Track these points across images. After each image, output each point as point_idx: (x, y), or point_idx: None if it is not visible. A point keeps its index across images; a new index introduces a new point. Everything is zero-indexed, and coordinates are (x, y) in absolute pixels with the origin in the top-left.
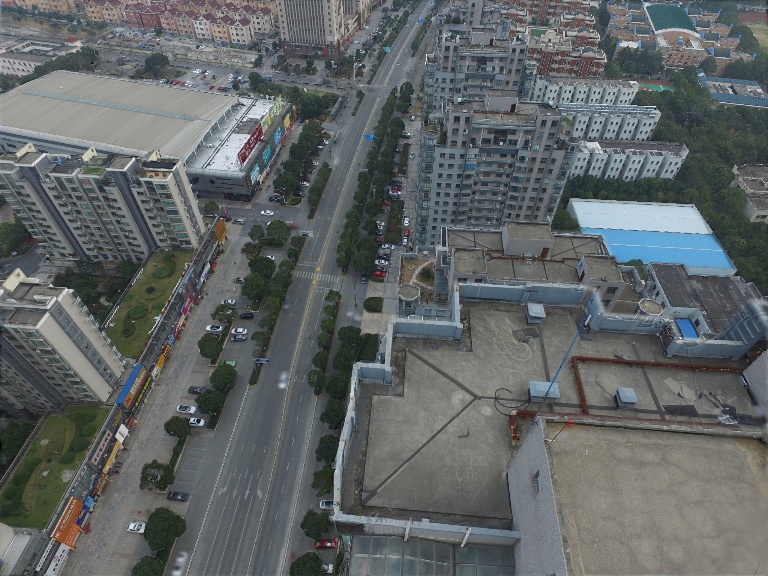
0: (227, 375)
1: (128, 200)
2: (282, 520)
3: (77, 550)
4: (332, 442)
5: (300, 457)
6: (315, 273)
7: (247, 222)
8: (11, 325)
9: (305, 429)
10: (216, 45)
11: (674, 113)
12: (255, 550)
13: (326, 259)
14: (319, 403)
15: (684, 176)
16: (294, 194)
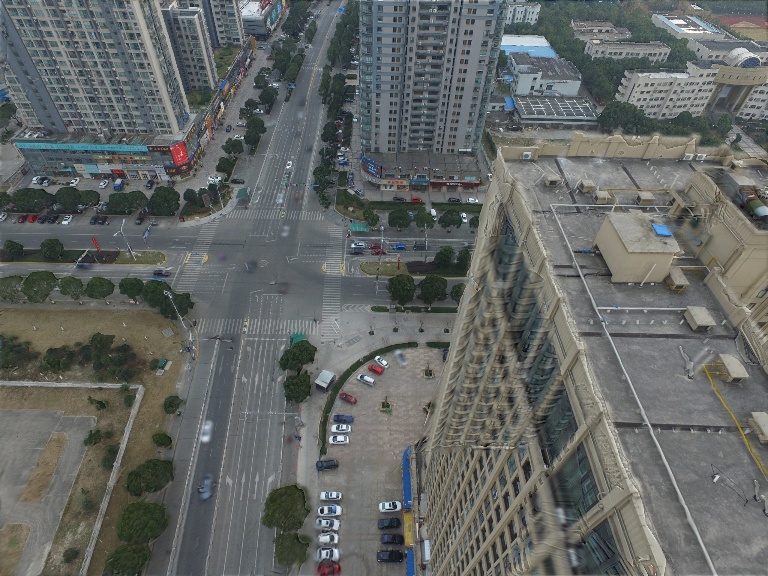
0: (274, 90)
1: (205, 5)
2: (312, 136)
3: (211, 144)
4: (335, 103)
5: (318, 121)
6: (314, 67)
7: (266, 49)
8: (182, 16)
9: (319, 114)
10: None
11: (545, 3)
12: (301, 143)
13: (320, 62)
14: (325, 107)
15: (540, 24)
16: (294, 38)
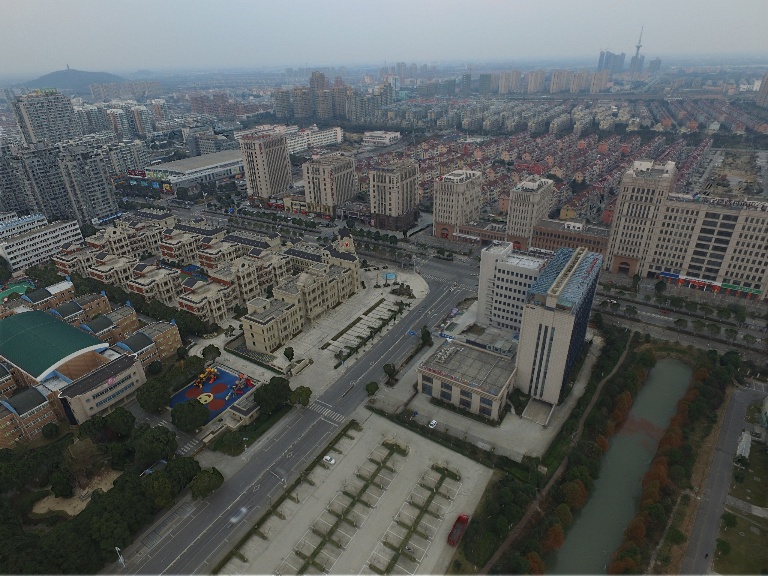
0: None
1: None
2: None
3: None
4: None
5: None
6: None
7: None
8: None
9: None
10: None
11: None
12: None
13: None
14: None
15: None
16: None
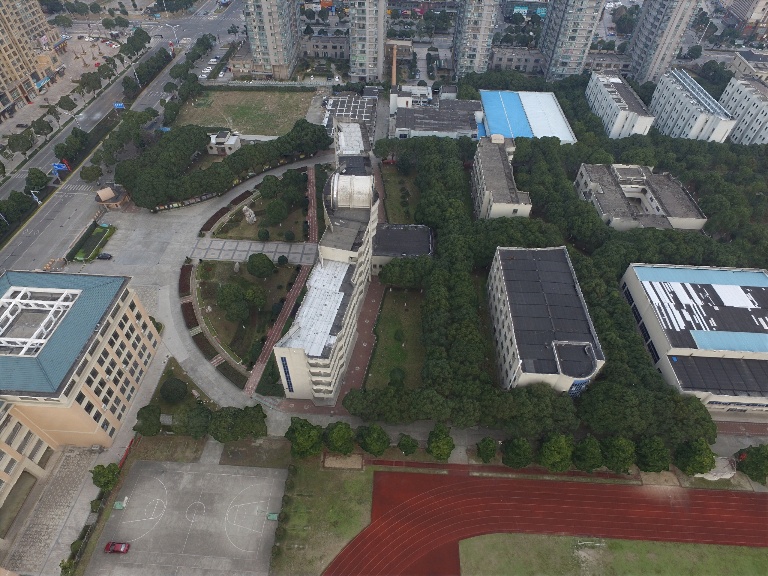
0: None
1: None
2: None
3: None
4: None
5: None
6: None
7: None
8: None
9: None
10: (711, 1)
11: None
12: None
13: None
14: None
15: None
16: None
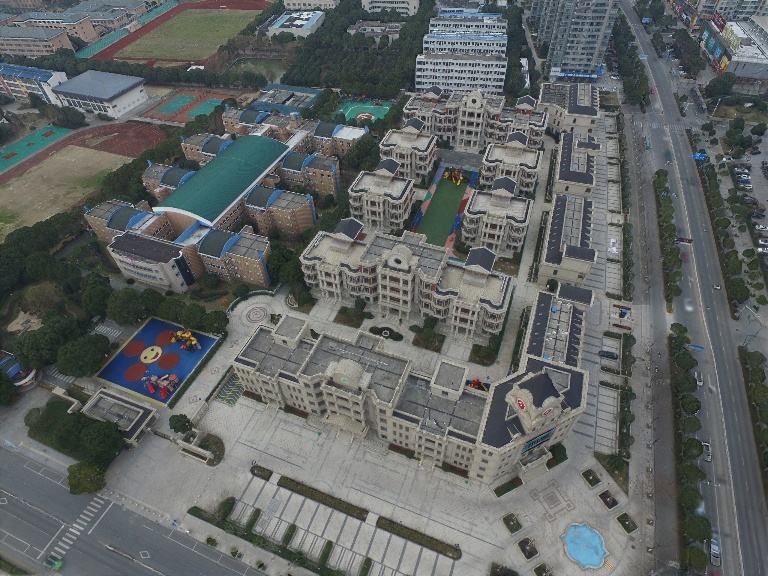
0: None
1: None
2: None
3: None
4: None
5: None
6: None
7: None
8: None
9: None
10: None
11: None
12: None
13: None
14: None
15: None
16: None
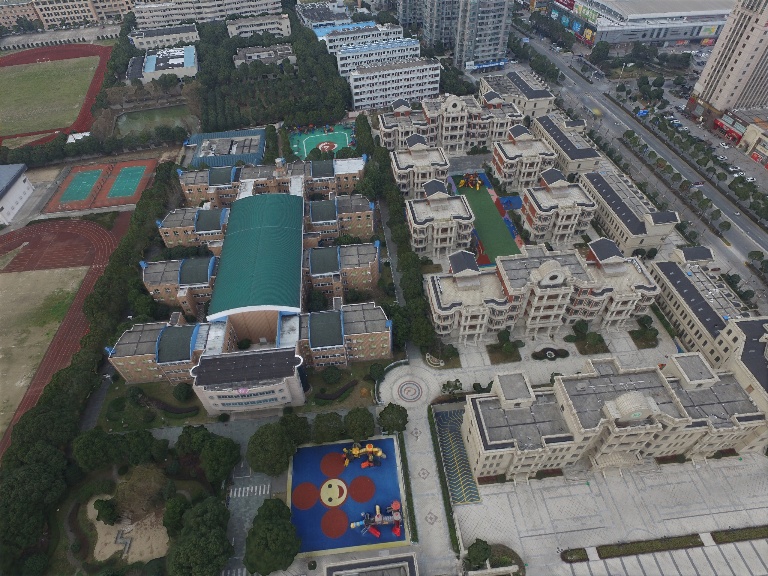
0: None
1: None
2: None
3: None
4: None
5: None
6: None
7: None
8: None
9: None
10: None
11: None
12: None
13: None
14: None
15: None
16: None
